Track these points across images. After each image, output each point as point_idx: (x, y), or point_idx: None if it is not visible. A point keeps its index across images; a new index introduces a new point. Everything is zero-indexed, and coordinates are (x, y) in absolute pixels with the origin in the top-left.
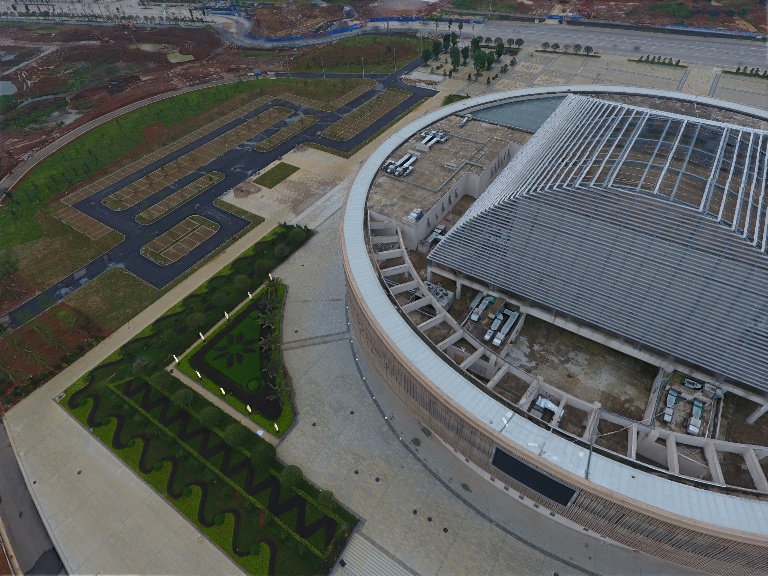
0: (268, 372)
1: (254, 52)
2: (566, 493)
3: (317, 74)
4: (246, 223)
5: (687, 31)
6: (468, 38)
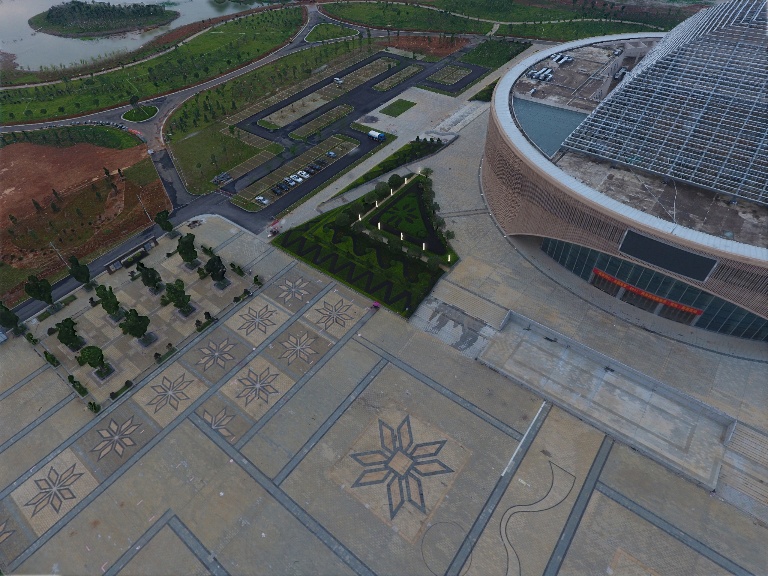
0: None
1: None
2: None
3: None
4: None
5: None
6: None
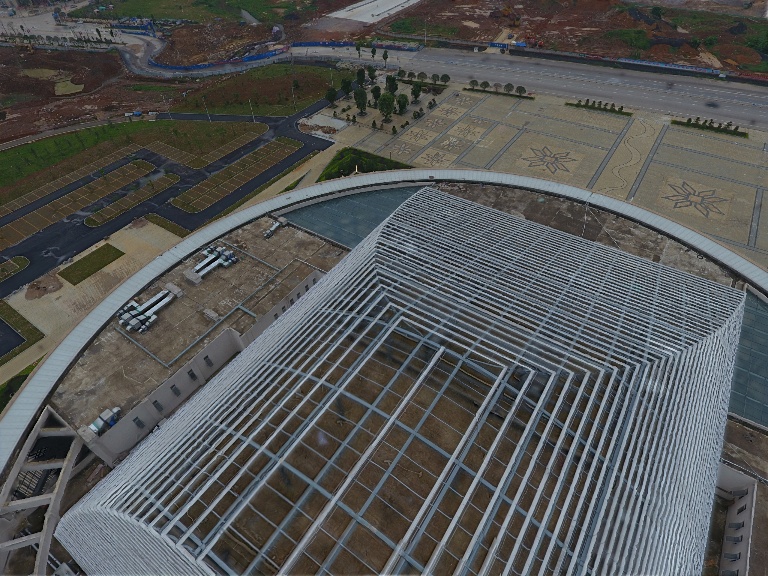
0: None
1: (148, 84)
2: None
3: (205, 115)
4: (18, 342)
5: (642, 65)
6: (393, 70)
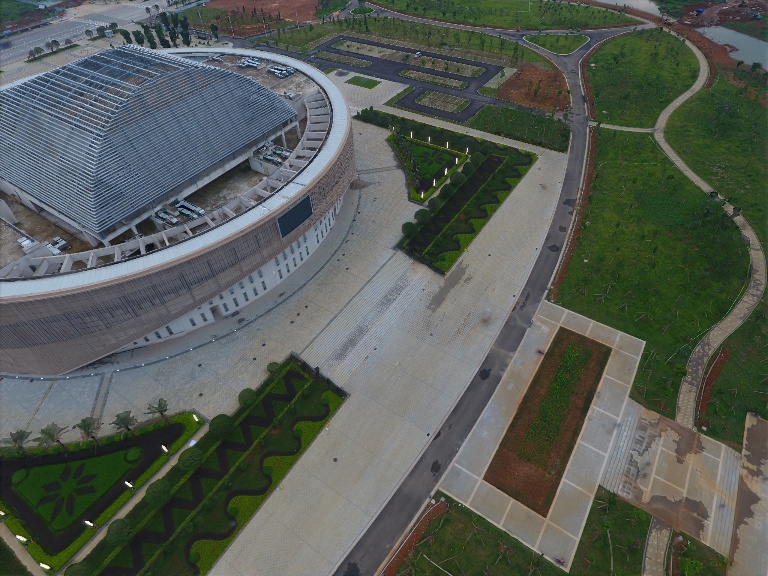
0: (130, 426)
1: None
2: (308, 203)
3: None
4: None
5: None
6: None
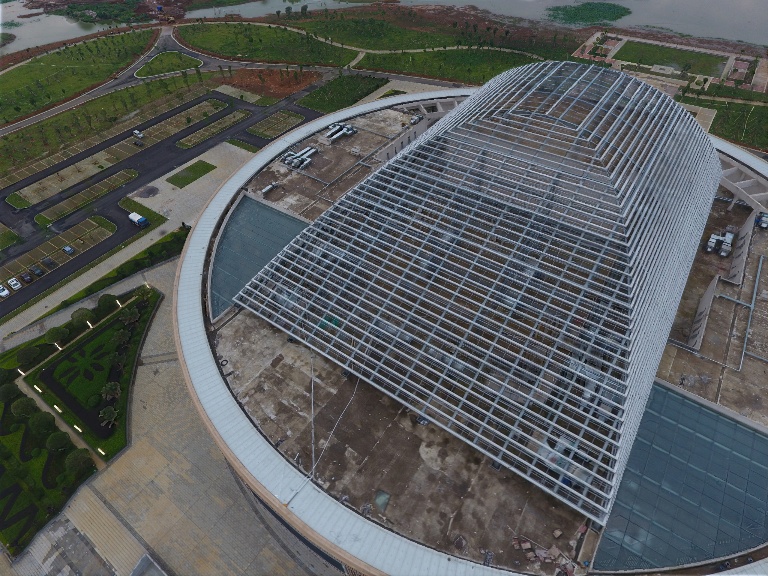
0: None
1: None
2: None
3: None
4: None
5: None
6: None
